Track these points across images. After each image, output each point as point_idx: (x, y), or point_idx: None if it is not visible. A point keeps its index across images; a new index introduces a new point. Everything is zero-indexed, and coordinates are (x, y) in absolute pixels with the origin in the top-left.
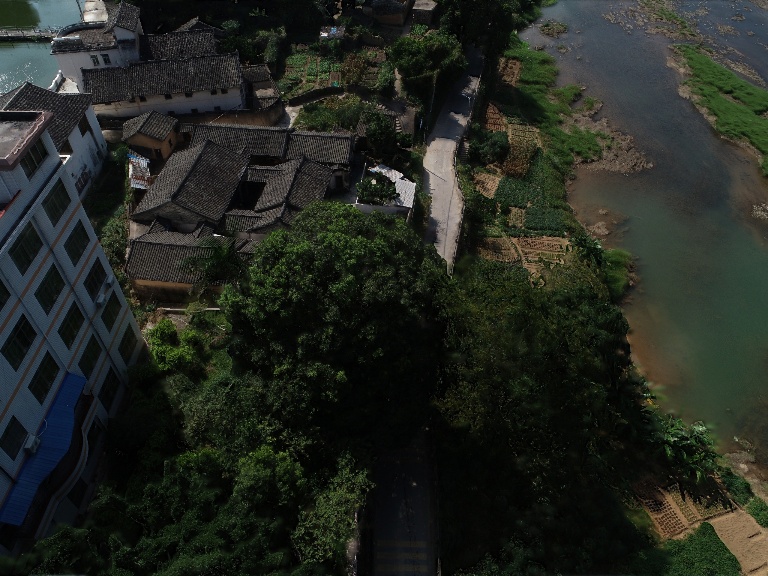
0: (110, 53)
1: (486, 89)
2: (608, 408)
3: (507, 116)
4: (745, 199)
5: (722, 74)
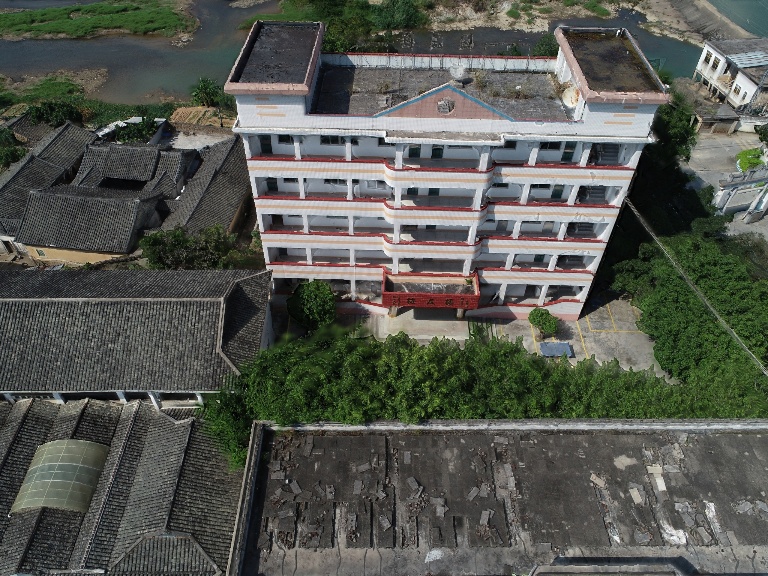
0: None
1: None
2: None
3: None
4: (164, 46)
5: (5, 18)
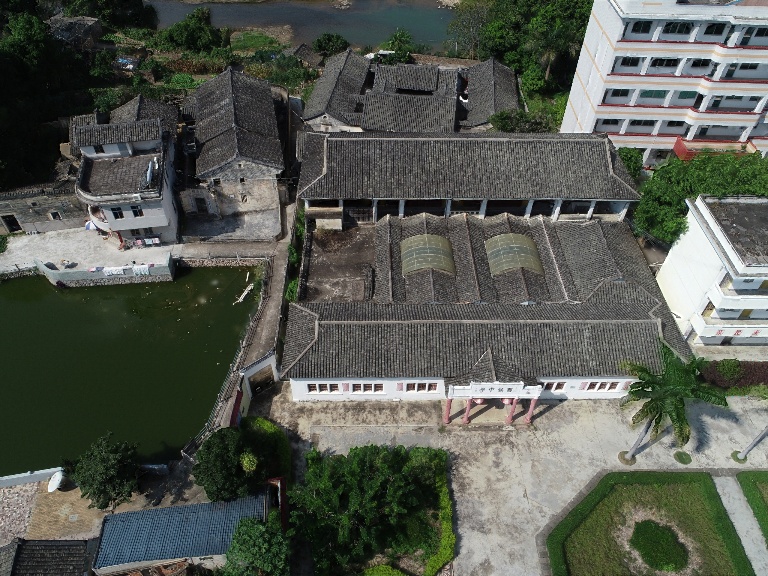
0: None
1: None
2: None
3: None
4: (329, 8)
5: None
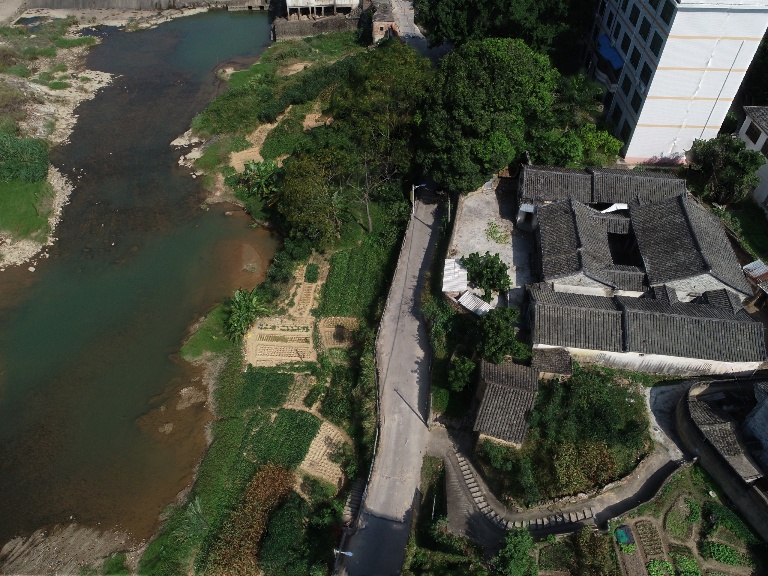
0: None
1: None
2: (325, 120)
3: None
4: None
5: None
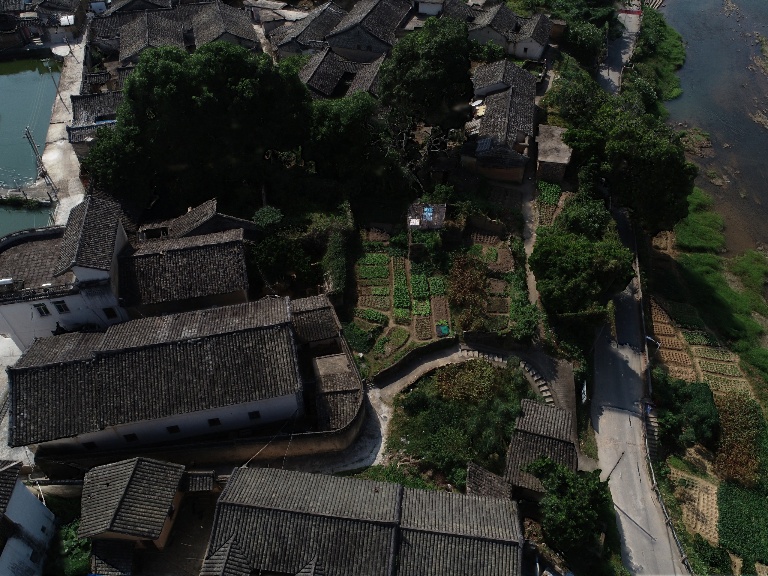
0: (67, 299)
1: (645, 278)
2: None
3: (683, 328)
4: None
5: None
